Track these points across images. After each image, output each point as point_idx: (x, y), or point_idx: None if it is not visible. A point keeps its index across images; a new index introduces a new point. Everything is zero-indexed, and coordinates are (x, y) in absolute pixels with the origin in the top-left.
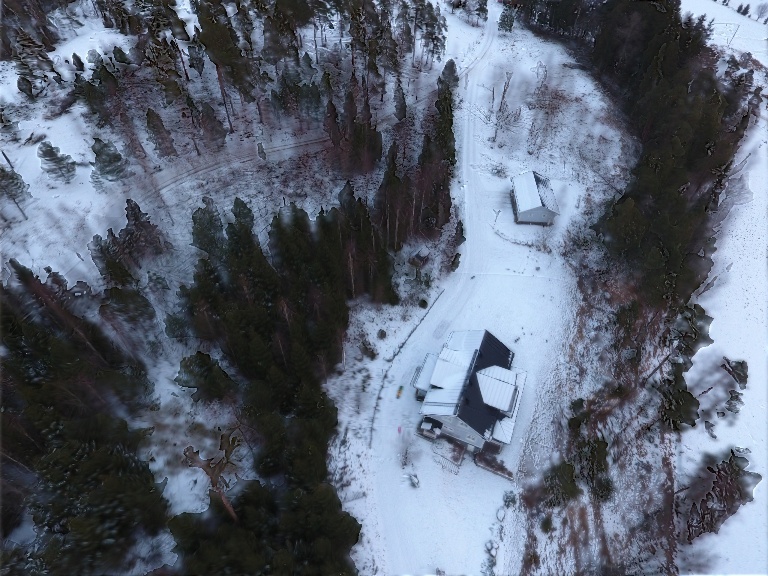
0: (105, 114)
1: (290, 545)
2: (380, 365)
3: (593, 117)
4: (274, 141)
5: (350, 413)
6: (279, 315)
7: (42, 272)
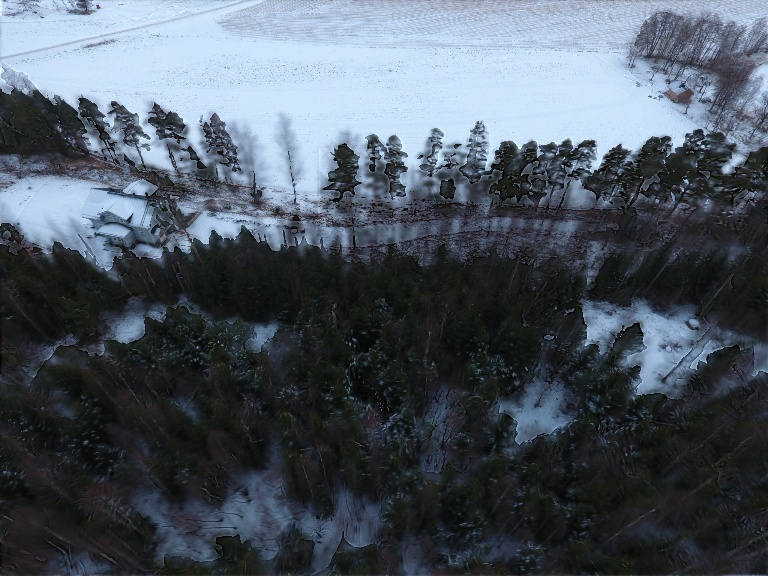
0: None
1: None
2: None
3: None
4: None
5: None
6: (33, 264)
7: None
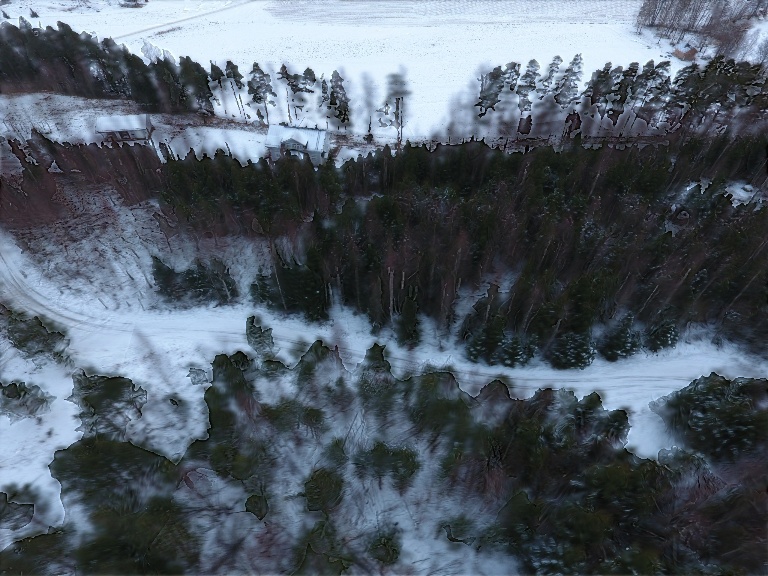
0: None
1: None
2: None
3: (7, 99)
4: None
5: None
6: None
7: (227, 351)
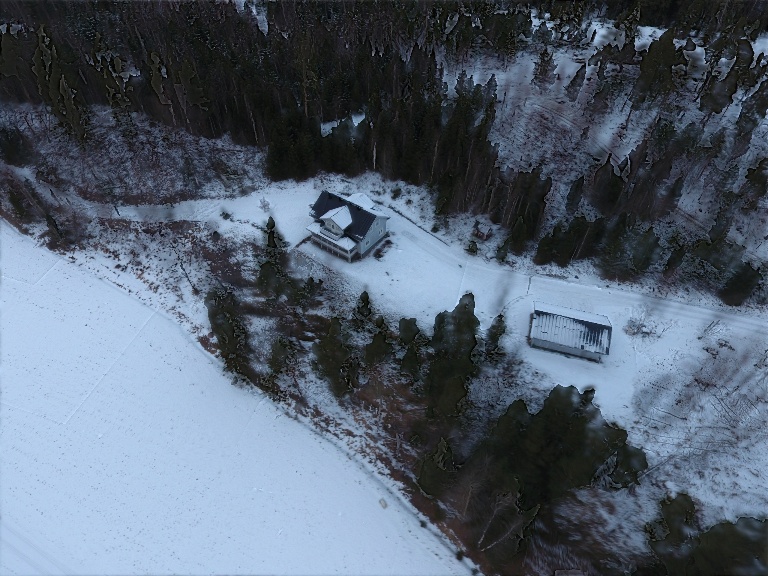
0: (600, 66)
1: (292, 136)
2: (387, 201)
3: None
4: (620, 150)
5: (359, 184)
6: None
7: None
